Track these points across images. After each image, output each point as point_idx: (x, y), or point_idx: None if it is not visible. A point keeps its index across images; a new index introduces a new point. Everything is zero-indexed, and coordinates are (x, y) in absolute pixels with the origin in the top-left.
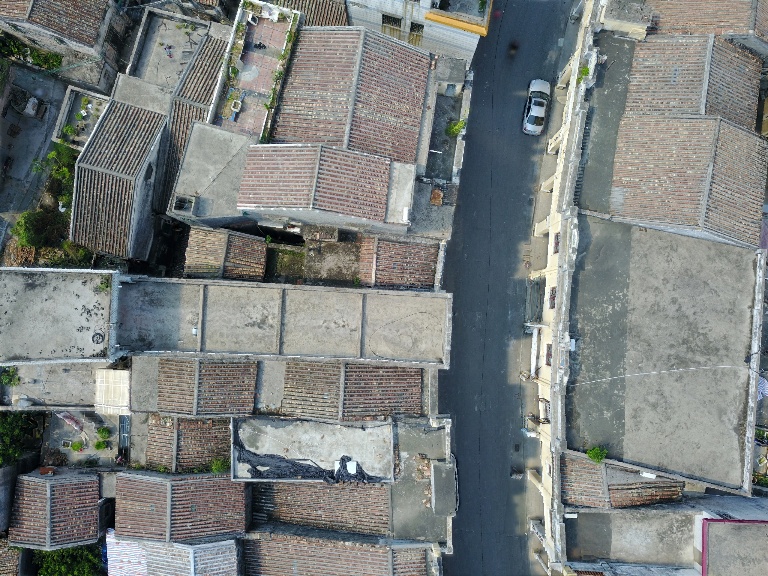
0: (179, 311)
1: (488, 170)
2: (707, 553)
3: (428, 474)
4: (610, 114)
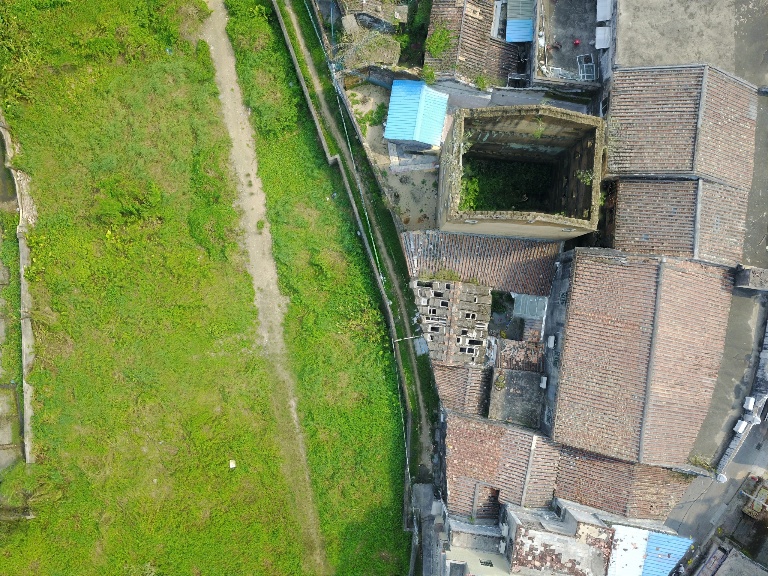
0: None
1: None
2: None
3: None
4: (760, 193)
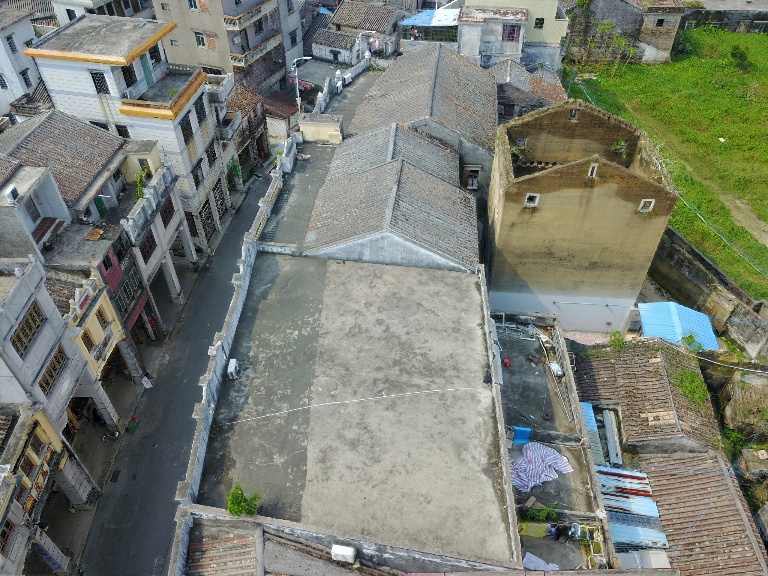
0: None
1: None
2: None
3: None
4: (310, 187)
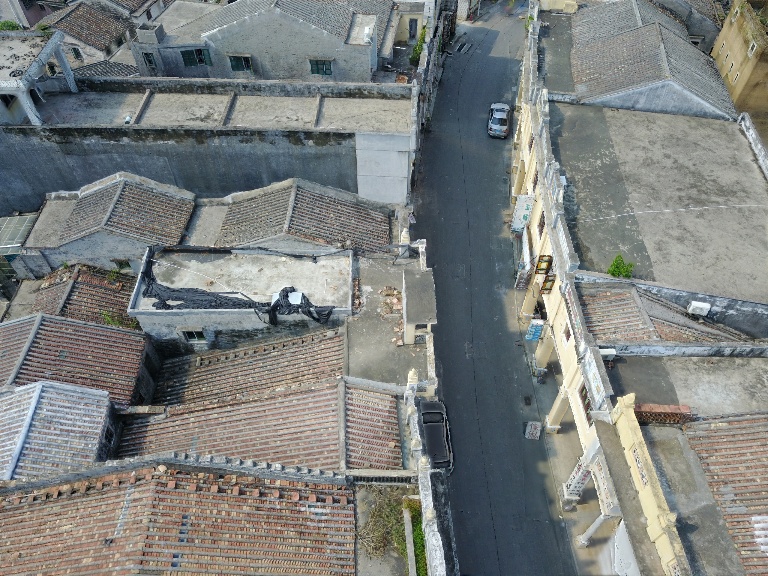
0: (117, 111)
1: (459, 160)
2: None
3: (399, 308)
4: (560, 50)
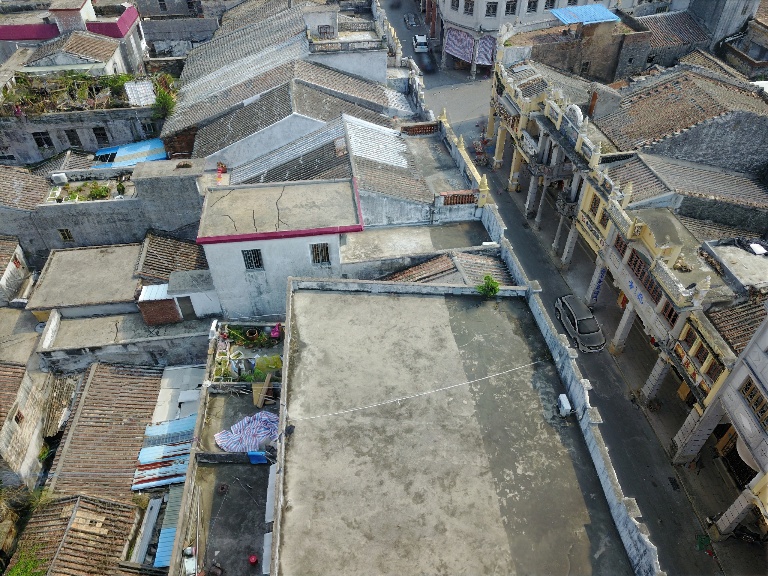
0: None
1: None
2: (357, 203)
3: None
4: None
